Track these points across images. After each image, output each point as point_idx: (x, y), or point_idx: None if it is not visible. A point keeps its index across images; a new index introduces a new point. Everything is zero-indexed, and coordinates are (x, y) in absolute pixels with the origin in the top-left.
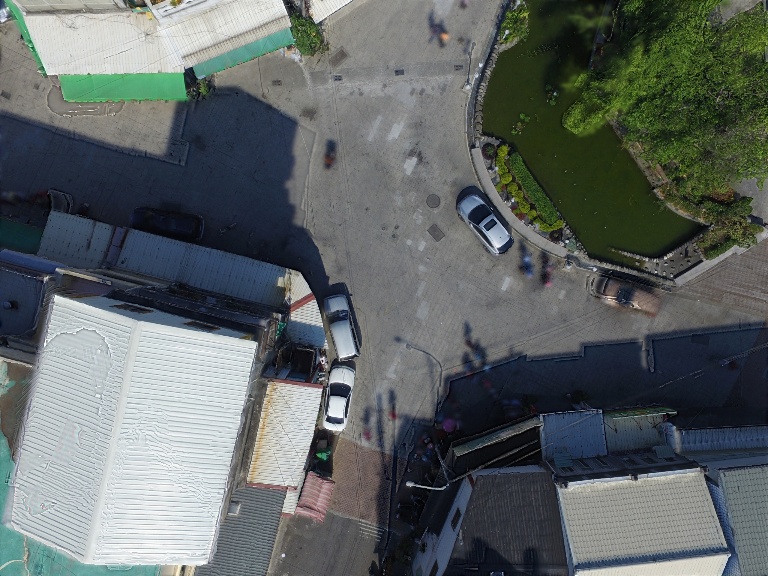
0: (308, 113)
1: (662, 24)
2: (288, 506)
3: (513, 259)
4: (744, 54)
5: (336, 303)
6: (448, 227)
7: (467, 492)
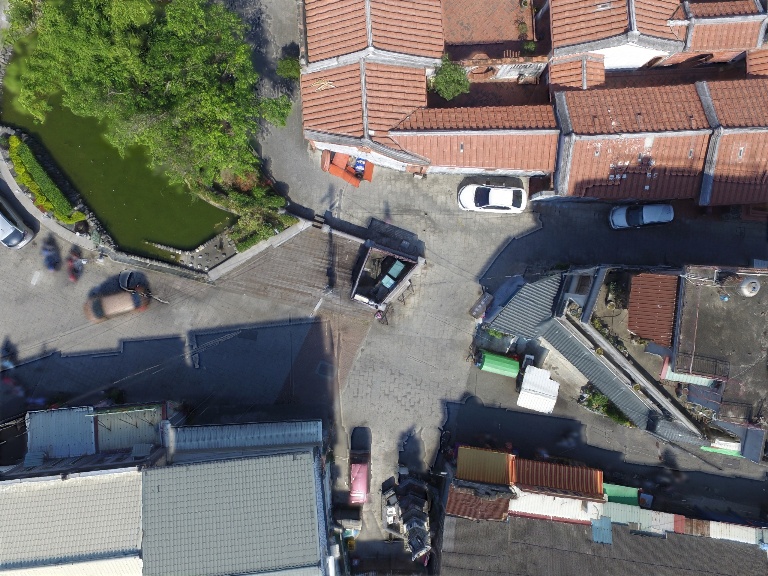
0: None
1: (62, 6)
2: None
3: (42, 252)
4: (193, 38)
5: None
6: None
7: None
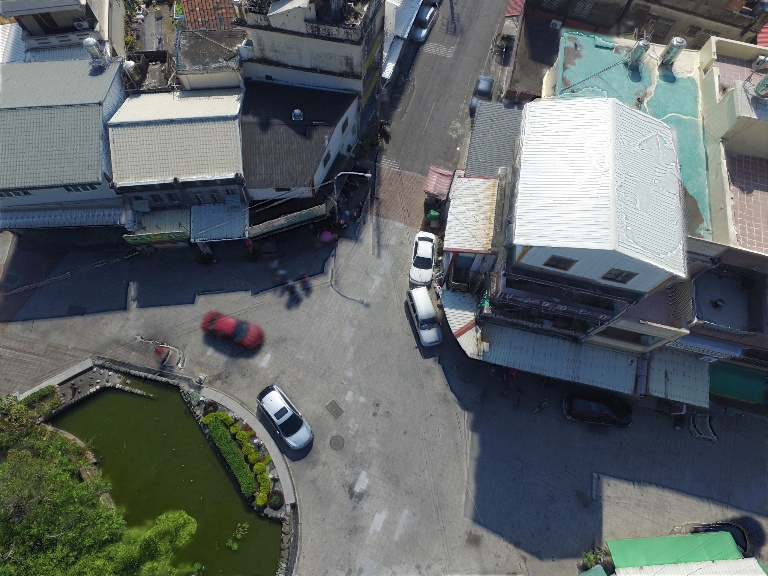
0: (474, 540)
1: None
2: (460, 175)
3: (257, 385)
4: None
5: (431, 336)
6: (322, 416)
7: (317, 177)
